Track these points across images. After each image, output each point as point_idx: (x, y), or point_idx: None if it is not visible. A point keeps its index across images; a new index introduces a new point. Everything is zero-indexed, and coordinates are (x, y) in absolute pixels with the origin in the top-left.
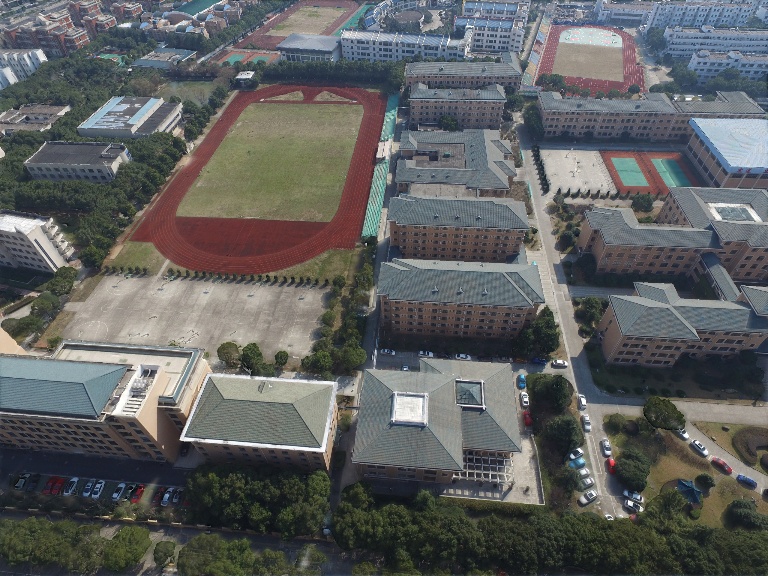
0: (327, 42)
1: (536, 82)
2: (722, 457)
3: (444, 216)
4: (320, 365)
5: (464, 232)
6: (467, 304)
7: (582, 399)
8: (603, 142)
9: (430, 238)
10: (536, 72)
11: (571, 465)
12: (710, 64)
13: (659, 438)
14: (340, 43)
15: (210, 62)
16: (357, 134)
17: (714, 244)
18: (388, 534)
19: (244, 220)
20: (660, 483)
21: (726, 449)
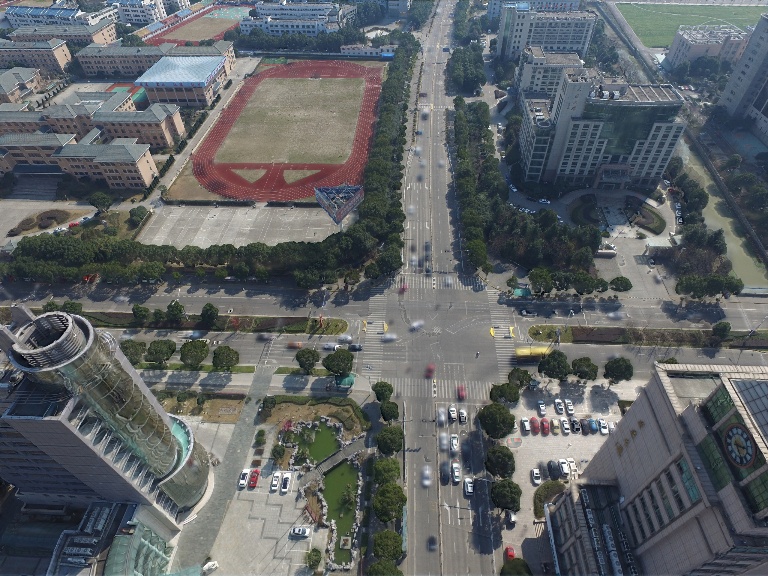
0: None
1: (121, 41)
2: None
3: None
4: None
5: None
6: None
7: None
8: (124, 78)
9: None
10: (150, 37)
11: None
12: (250, 26)
13: None
14: (7, 17)
15: None
16: None
17: (42, 119)
18: None
19: None
20: None
21: None
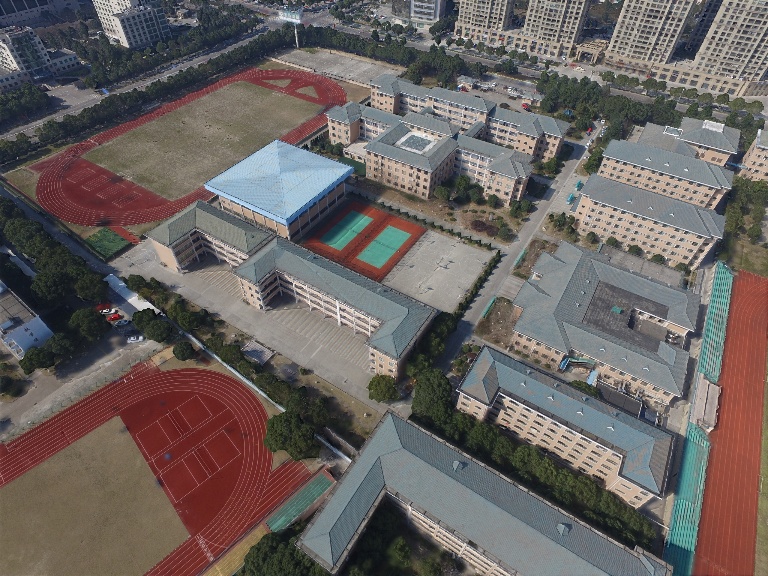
0: None
1: None
2: None
3: None
4: None
5: None
6: None
7: None
8: None
9: None
10: None
11: None
12: None
13: None
14: None
15: None
16: (762, 498)
17: None
18: None
19: None
20: (572, 123)
21: None
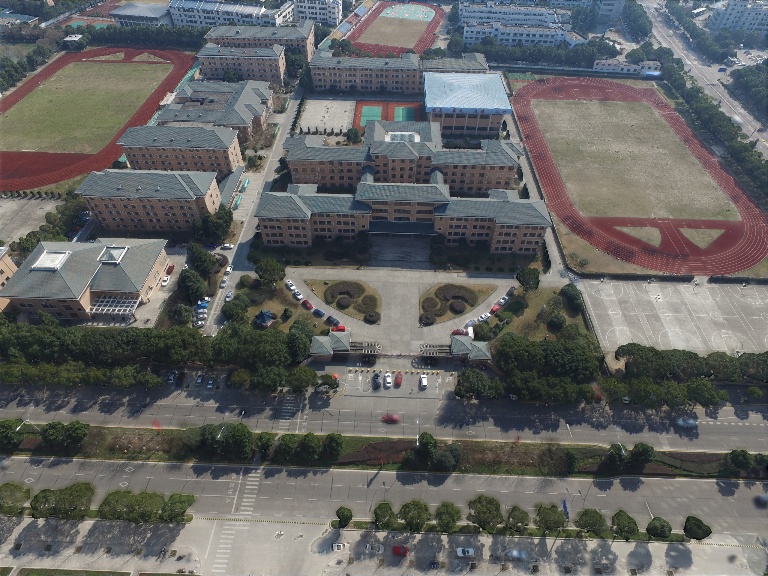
0: (156, 10)
1: (329, 46)
2: (312, 300)
3: (162, 139)
4: (21, 246)
5: (181, 153)
6: (143, 198)
7: (228, 267)
8: (363, 94)
9: (157, 159)
10: None
11: (195, 308)
12: (476, 33)
13: (273, 290)
14: (169, 11)
15: (50, 27)
16: (156, 87)
17: (368, 158)
18: (5, 339)
19: (20, 153)
20: None
21: (318, 295)
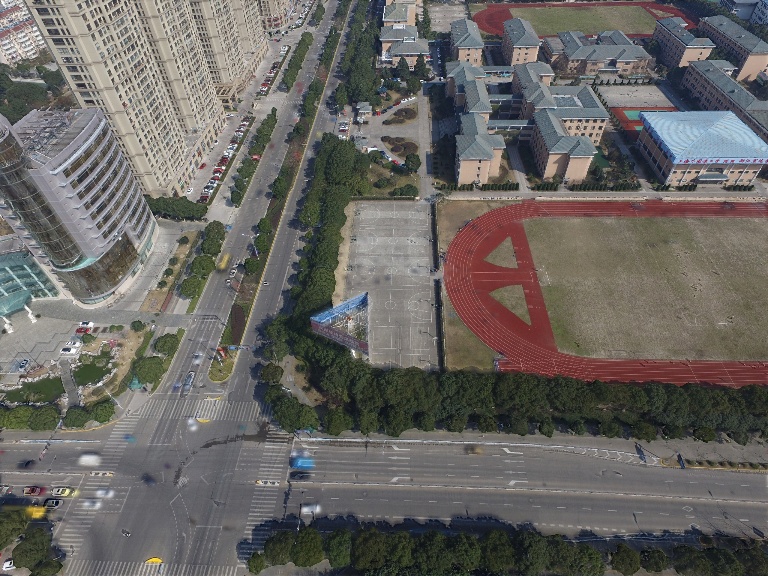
0: None
1: None
2: None
3: None
4: None
5: None
6: None
7: None
8: (693, 109)
9: None
10: None
11: None
12: None
13: None
14: None
15: None
16: (625, 34)
17: None
18: None
19: None
20: None
21: None
